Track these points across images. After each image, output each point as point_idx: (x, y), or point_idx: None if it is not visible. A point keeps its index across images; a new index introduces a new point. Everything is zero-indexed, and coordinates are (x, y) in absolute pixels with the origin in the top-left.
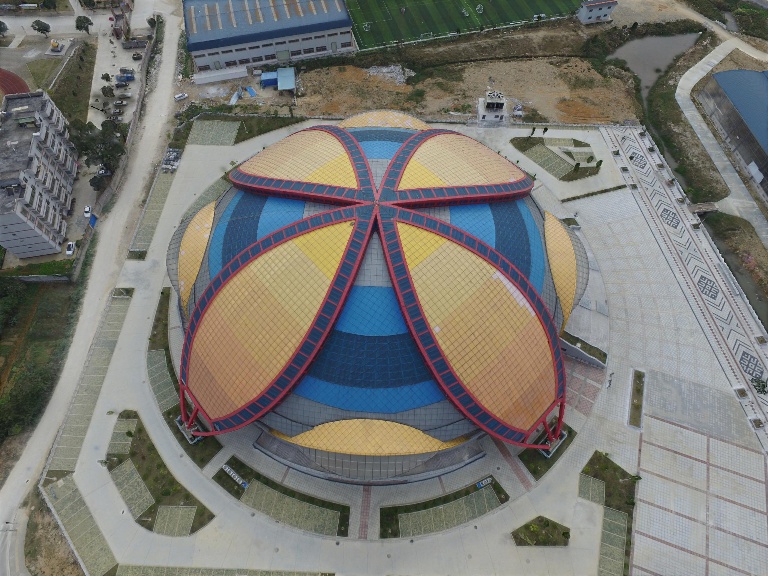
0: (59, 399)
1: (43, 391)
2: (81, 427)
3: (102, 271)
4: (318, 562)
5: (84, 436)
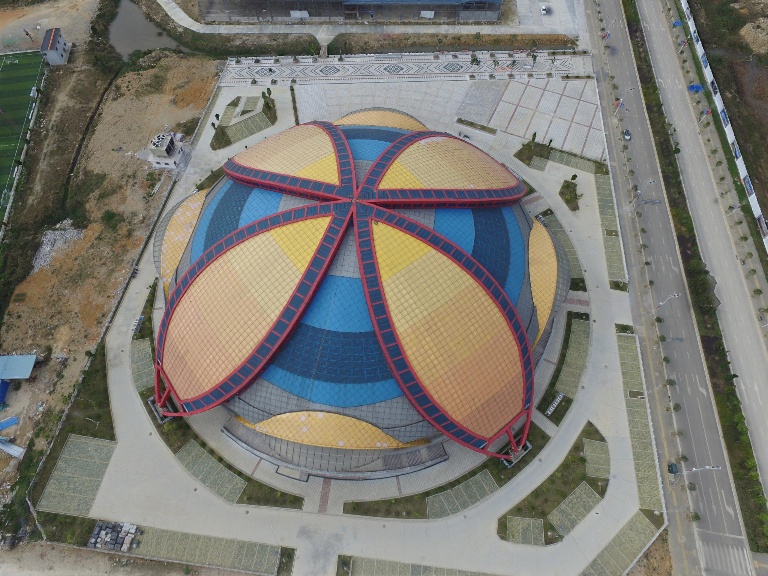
0: None
1: None
2: None
3: None
4: (609, 335)
5: None
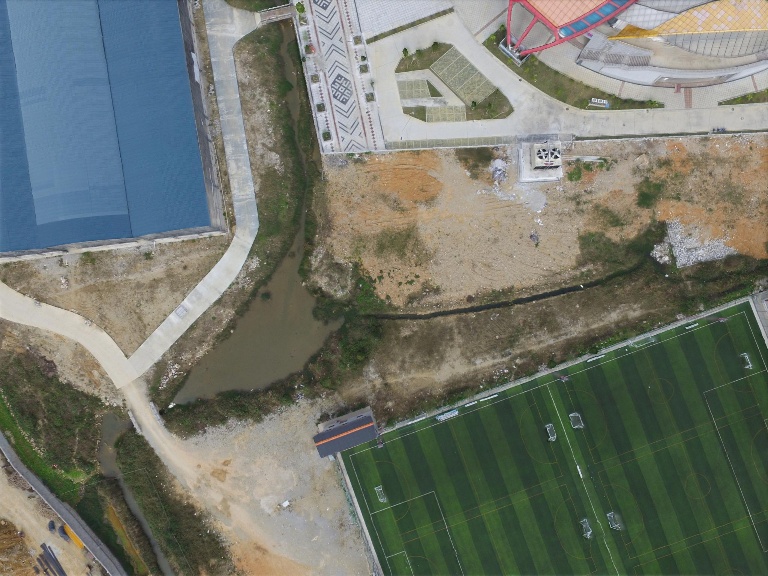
0: None
1: None
2: None
3: None
4: None
5: None
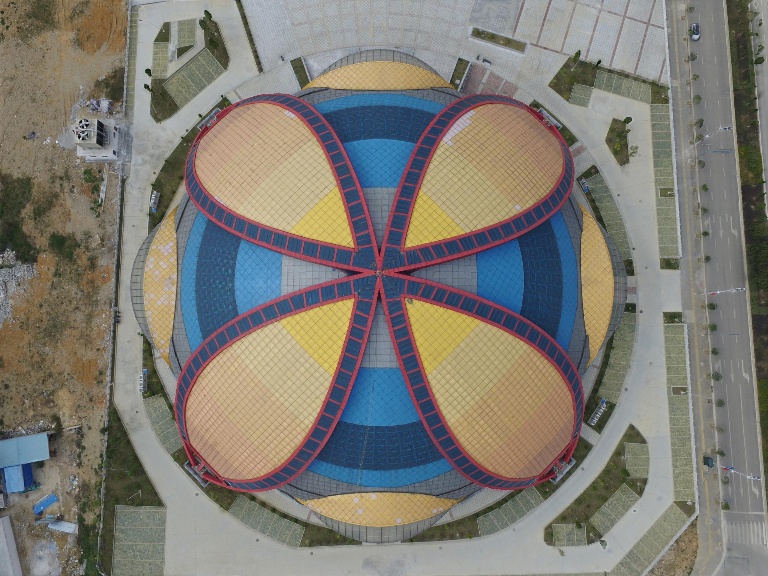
0: None
1: None
2: None
3: None
4: (656, 327)
5: (572, 575)
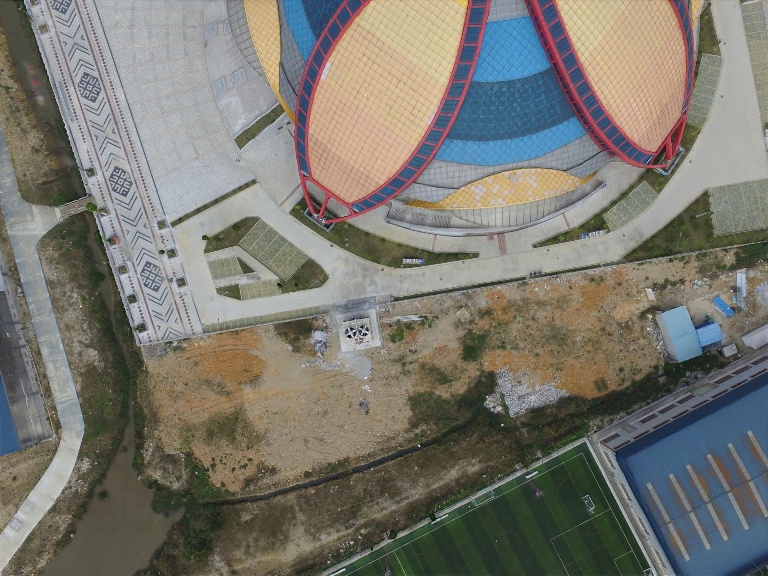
0: None
1: None
2: None
3: None
4: None
5: None
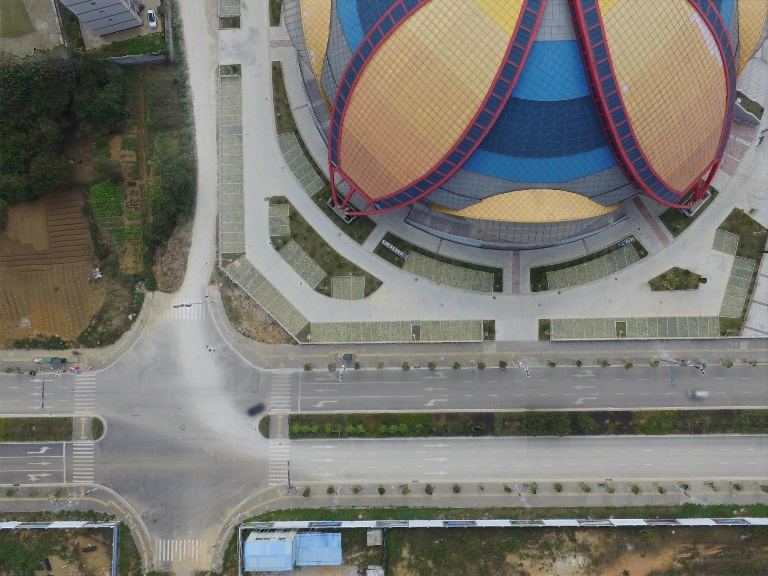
0: (206, 189)
1: (190, 182)
2: (237, 214)
3: (197, 45)
4: (479, 312)
5: (243, 222)
